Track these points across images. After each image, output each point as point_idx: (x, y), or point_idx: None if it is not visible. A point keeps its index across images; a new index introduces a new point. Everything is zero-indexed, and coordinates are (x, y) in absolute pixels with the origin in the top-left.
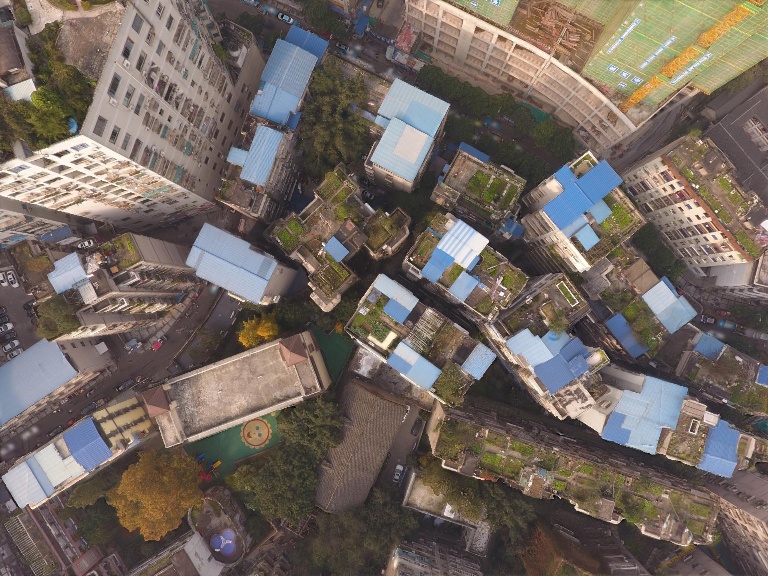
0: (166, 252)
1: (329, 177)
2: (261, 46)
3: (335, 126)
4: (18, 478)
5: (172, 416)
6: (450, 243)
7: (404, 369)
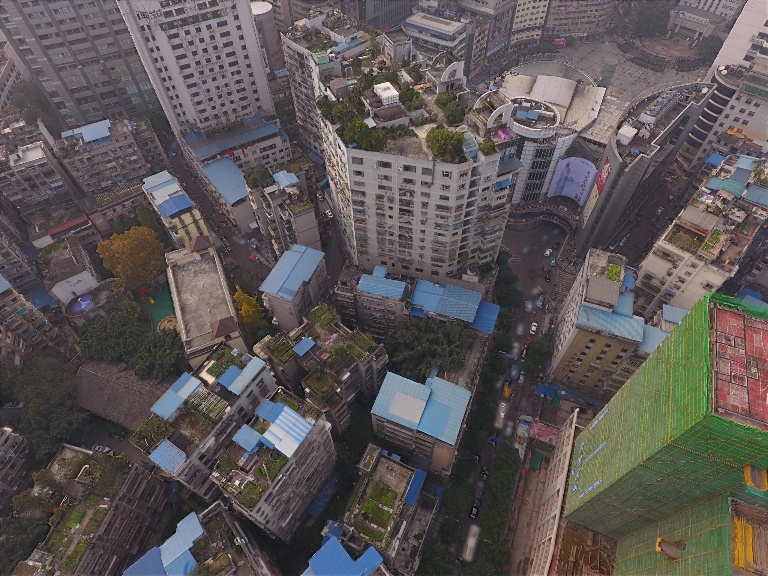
0: (311, 241)
1: (367, 335)
2: (502, 310)
3: (419, 345)
4: (163, 177)
5: (188, 255)
6: (289, 418)
7: (176, 387)
